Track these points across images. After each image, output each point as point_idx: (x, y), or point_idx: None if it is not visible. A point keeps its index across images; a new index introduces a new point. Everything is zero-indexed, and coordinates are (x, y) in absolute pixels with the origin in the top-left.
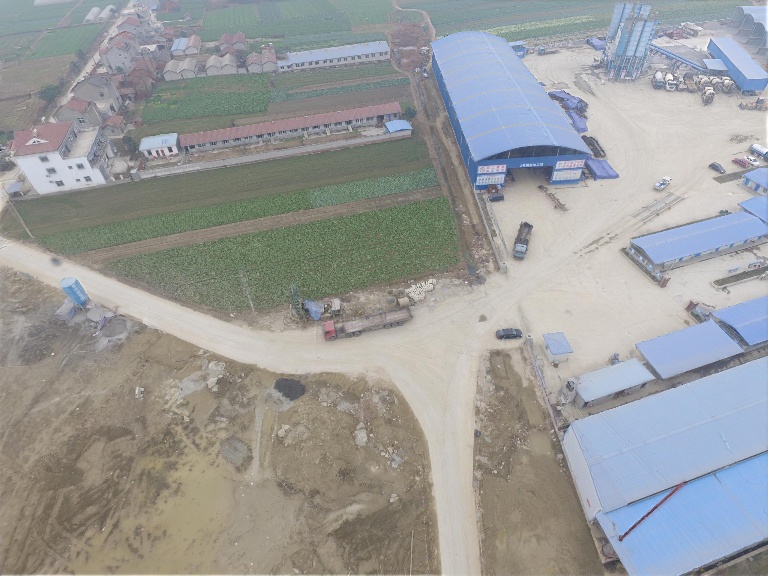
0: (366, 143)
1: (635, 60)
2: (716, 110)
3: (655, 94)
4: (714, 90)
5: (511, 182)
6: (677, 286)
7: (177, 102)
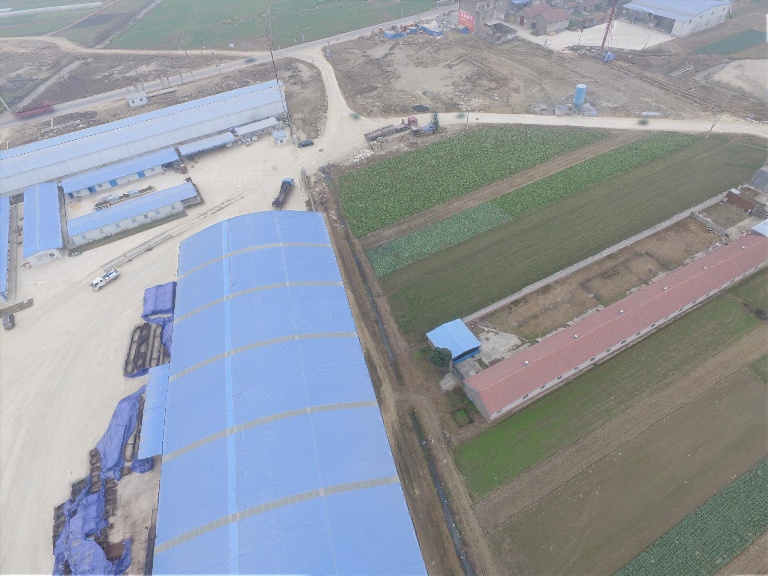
0: (493, 310)
1: None
2: None
3: None
4: None
5: None
6: None
7: None
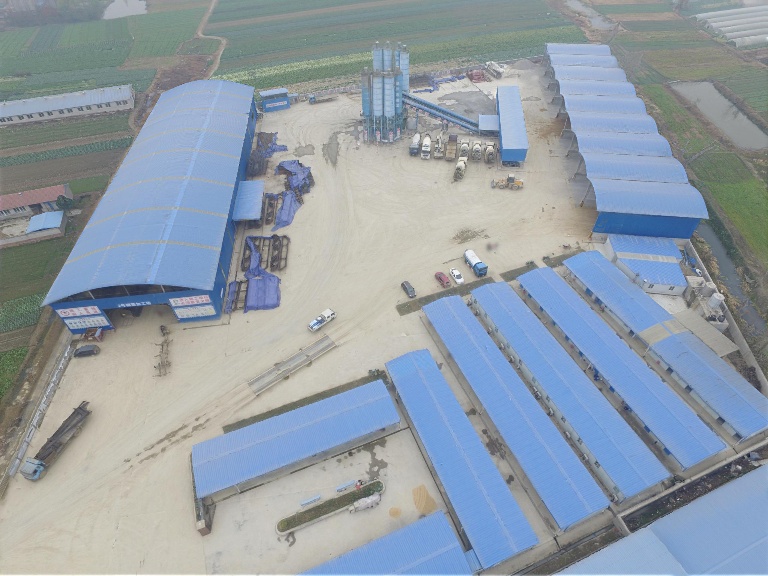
0: None
1: (386, 121)
2: (462, 189)
3: (406, 164)
4: (474, 159)
5: (133, 318)
6: (227, 531)
7: None
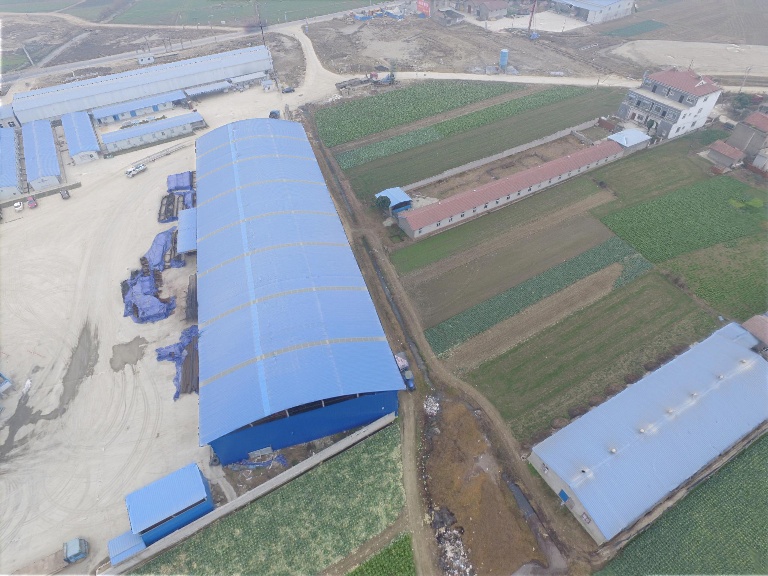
0: (424, 186)
1: None
2: None
3: None
4: None
5: None
6: None
7: (747, 211)
